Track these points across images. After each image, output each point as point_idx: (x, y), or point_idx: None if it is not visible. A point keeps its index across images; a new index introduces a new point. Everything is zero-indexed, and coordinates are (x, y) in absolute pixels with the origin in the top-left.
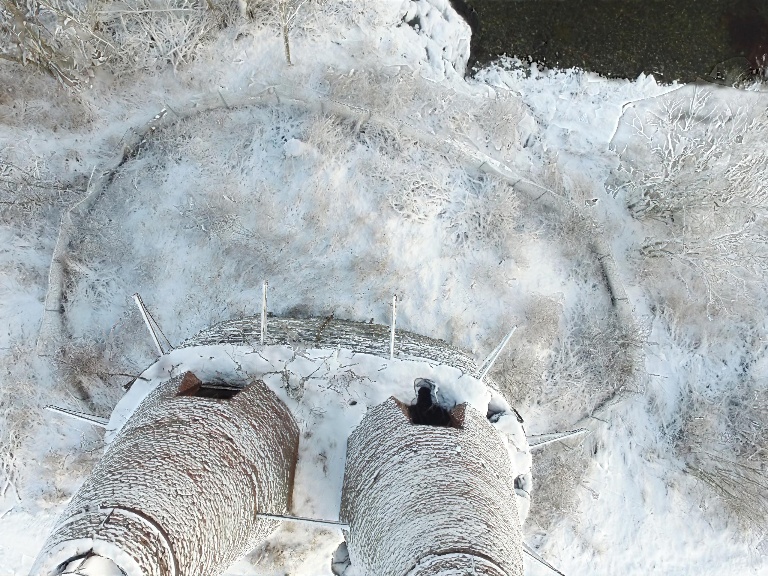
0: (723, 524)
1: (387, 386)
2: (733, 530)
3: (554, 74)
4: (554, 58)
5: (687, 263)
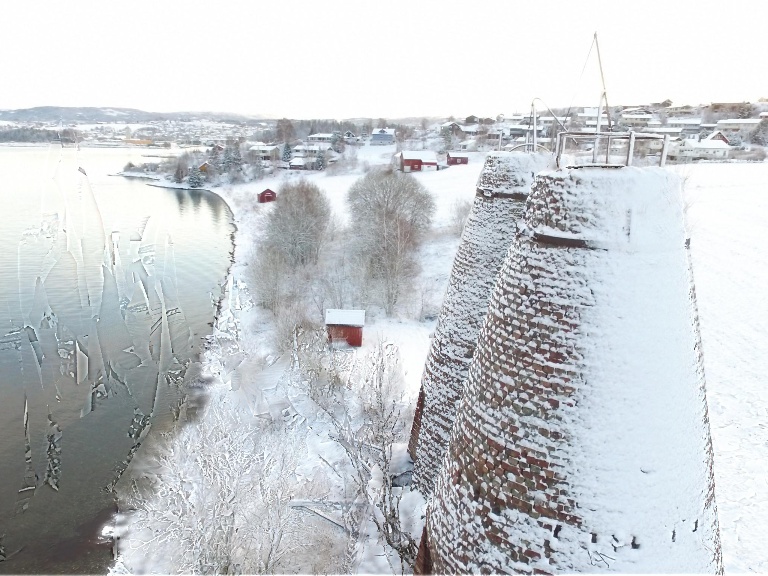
0: None
1: None
2: None
3: None
4: None
5: (282, 570)
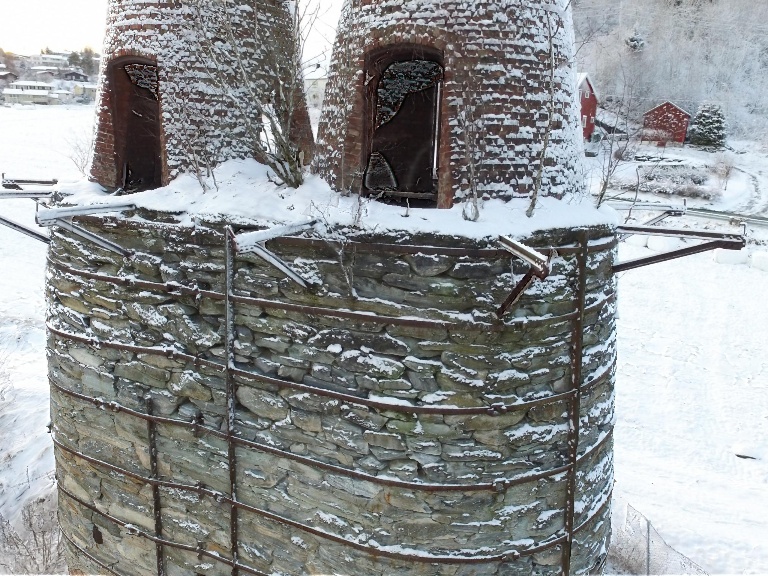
0: (5, 418)
1: (166, 189)
2: (3, 412)
3: None
4: None
5: None
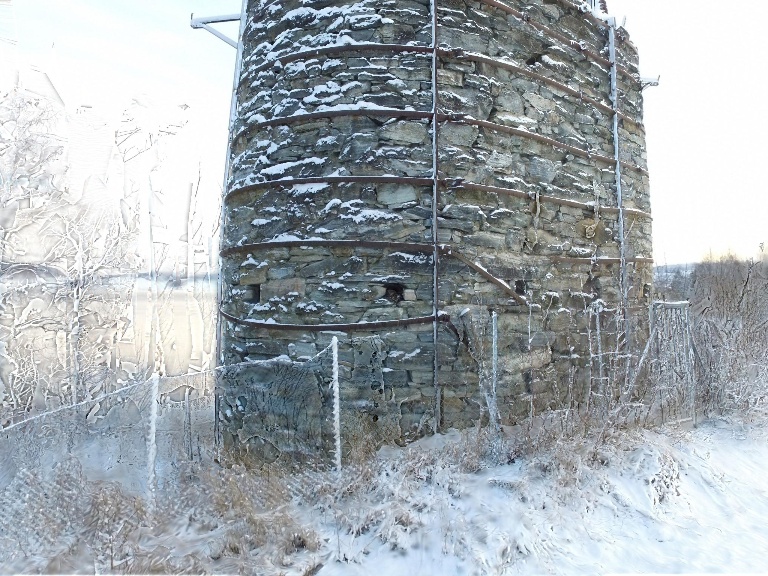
0: None
1: None
2: None
3: None
4: None
5: None
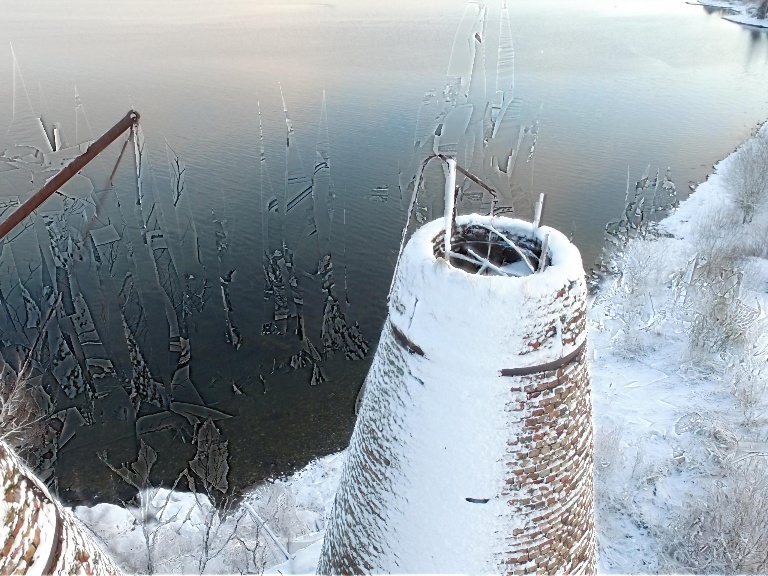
0: None
1: None
2: None
3: (298, 476)
4: (289, 468)
5: None
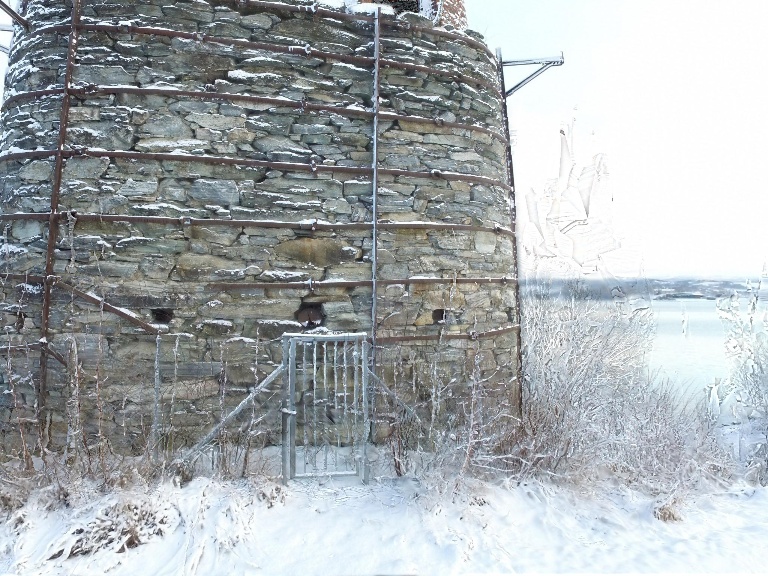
0: None
1: None
2: None
3: None
4: None
5: None
